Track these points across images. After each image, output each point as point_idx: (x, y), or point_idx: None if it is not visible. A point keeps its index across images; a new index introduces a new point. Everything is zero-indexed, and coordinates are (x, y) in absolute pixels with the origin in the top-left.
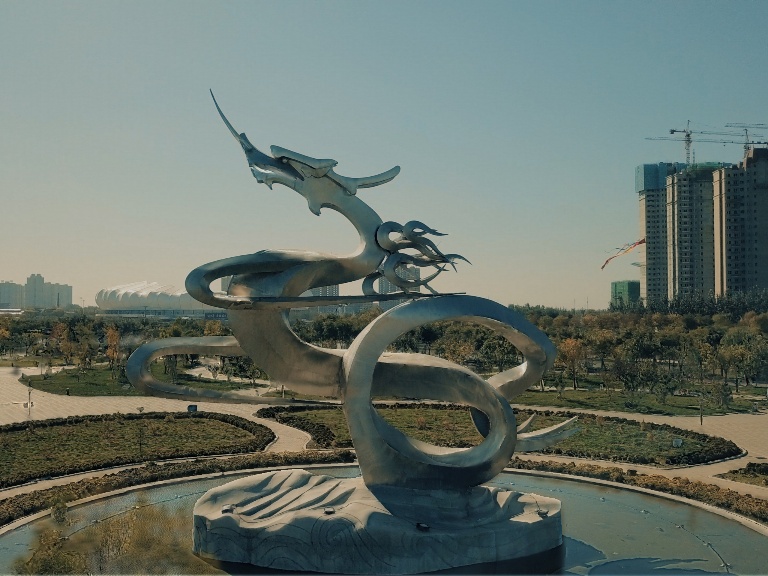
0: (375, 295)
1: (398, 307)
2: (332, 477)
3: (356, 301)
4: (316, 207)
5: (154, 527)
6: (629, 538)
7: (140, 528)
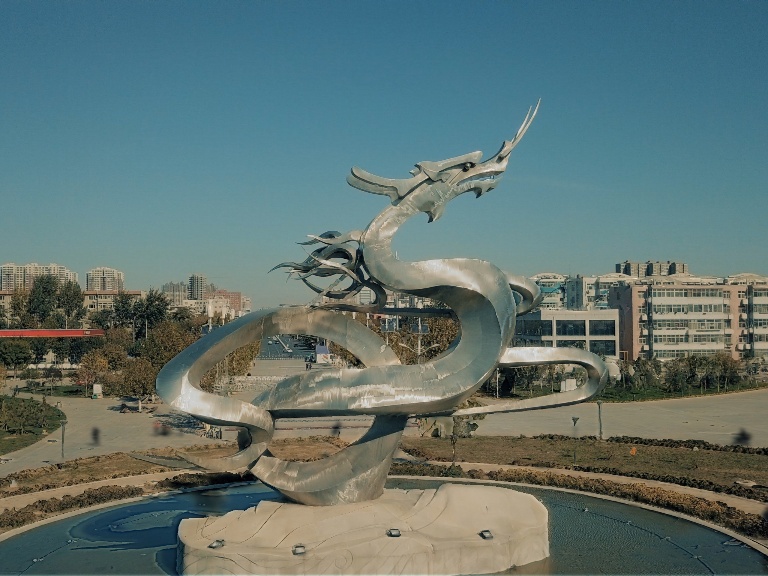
0: (372, 307)
1: (349, 319)
2: (420, 500)
3: (389, 313)
4: (431, 217)
5: (635, 575)
6: (102, 569)
7: (651, 575)
